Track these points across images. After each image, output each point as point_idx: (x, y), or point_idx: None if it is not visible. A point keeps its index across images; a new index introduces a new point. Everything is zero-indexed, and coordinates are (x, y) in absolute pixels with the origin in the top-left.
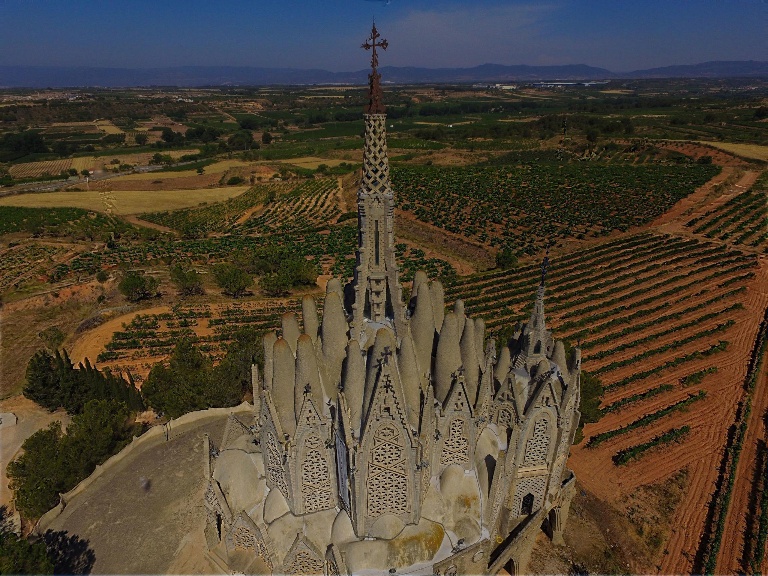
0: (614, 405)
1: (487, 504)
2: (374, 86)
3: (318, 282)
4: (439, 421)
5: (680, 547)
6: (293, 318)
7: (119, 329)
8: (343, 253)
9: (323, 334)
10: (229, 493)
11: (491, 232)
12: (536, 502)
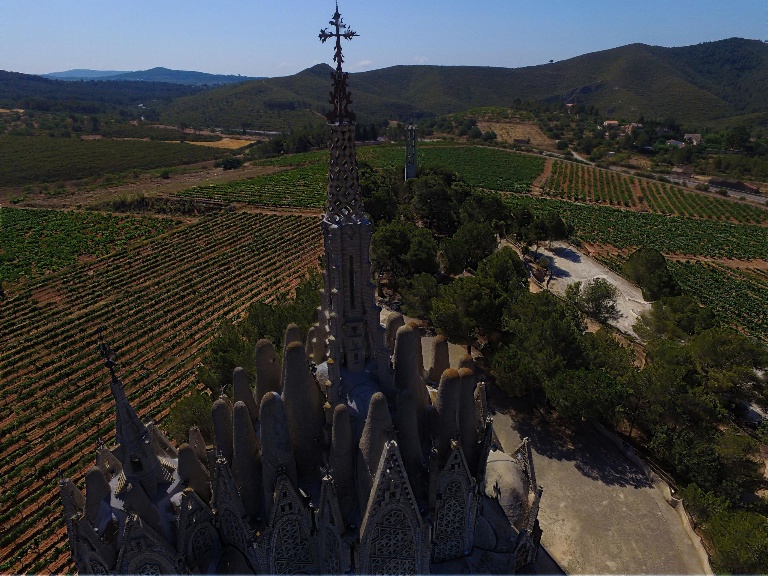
0: None
1: None
2: (340, 88)
3: None
4: None
5: None
6: None
7: None
8: None
9: None
10: None
11: None
12: None
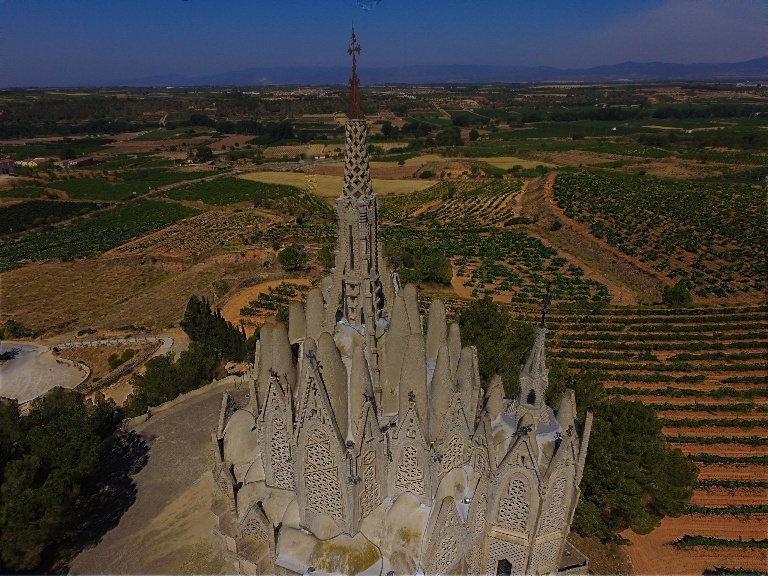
0: (739, 508)
1: (428, 547)
2: (354, 91)
3: (454, 283)
4: (391, 442)
5: None
6: (298, 307)
7: (267, 291)
8: (494, 258)
9: (306, 326)
10: (227, 446)
11: (677, 261)
12: (515, 573)
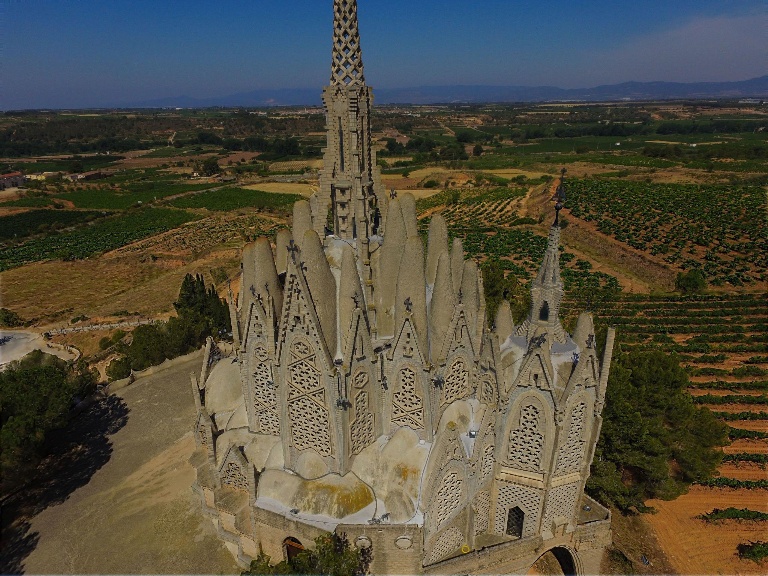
0: None
1: (428, 484)
2: None
3: None
4: (386, 365)
5: None
6: (287, 234)
7: None
8: (499, 254)
9: None
10: (208, 393)
11: (689, 254)
12: (529, 523)
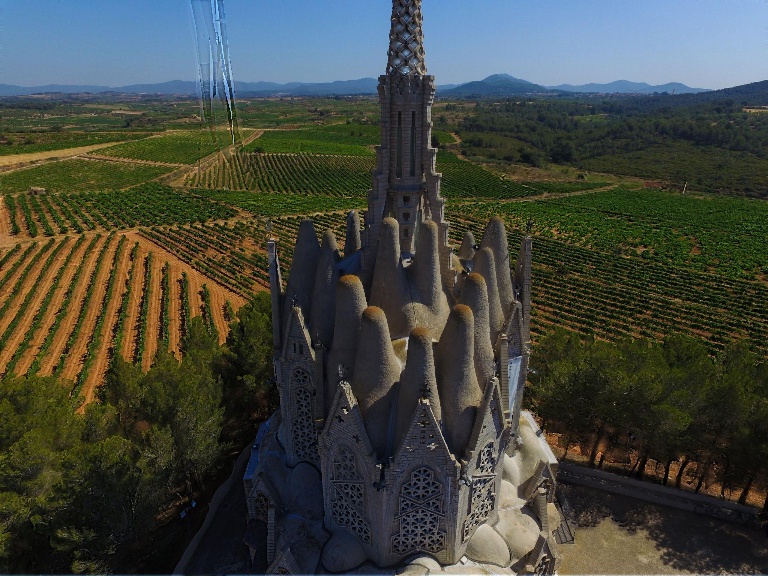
0: None
1: None
2: None
3: None
4: None
5: None
6: None
7: None
8: None
9: (435, 284)
10: None
11: None
12: None
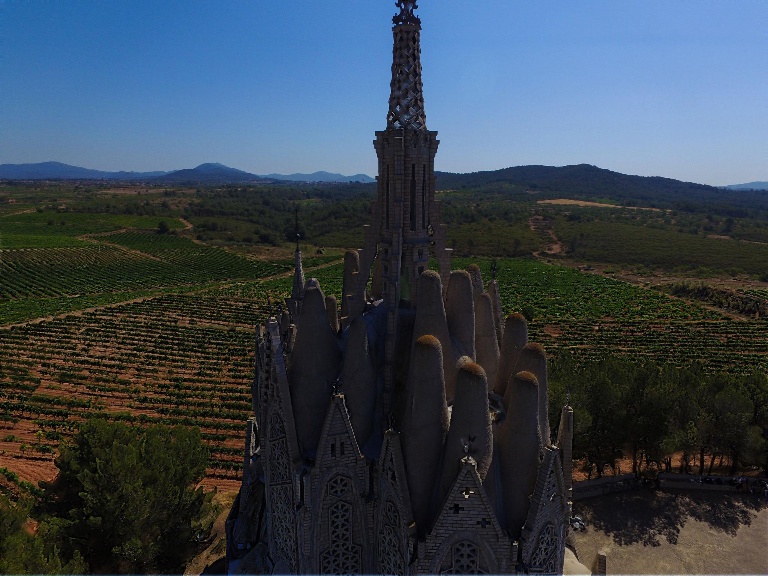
0: None
1: None
2: None
3: None
4: None
5: (237, 488)
6: None
7: None
8: None
9: None
10: None
11: None
12: None
